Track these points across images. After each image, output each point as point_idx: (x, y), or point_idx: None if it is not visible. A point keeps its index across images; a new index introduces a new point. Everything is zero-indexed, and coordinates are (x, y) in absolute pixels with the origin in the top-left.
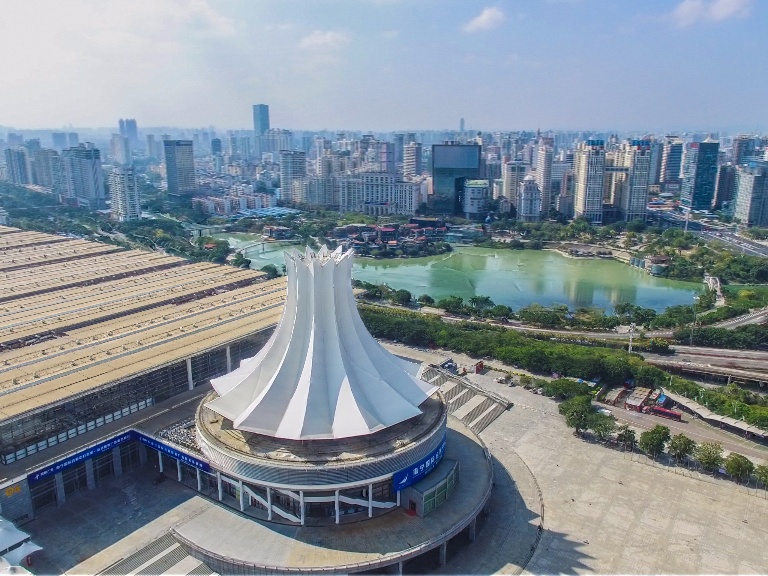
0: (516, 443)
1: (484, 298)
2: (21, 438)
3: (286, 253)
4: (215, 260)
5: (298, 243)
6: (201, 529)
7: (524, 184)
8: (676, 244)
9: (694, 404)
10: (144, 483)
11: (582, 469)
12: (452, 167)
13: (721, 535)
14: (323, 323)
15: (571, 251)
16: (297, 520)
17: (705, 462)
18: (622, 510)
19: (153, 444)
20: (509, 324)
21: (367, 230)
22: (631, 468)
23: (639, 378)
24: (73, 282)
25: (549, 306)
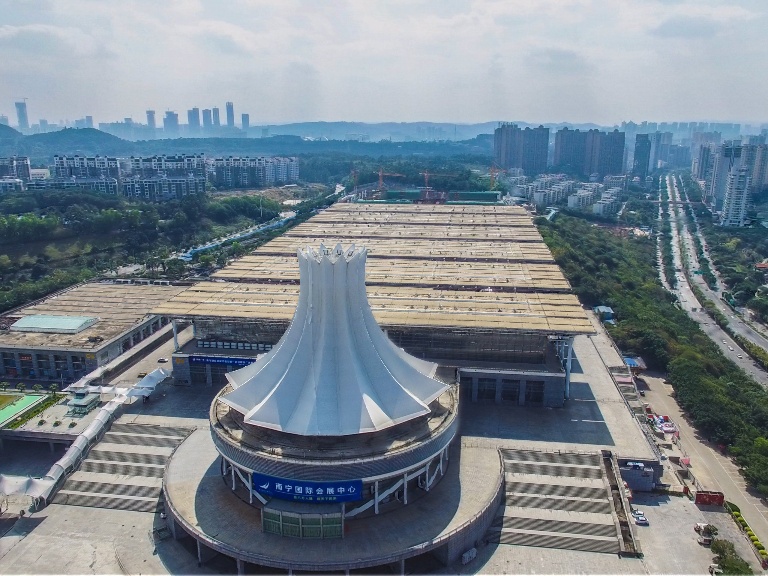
0: None
1: None
2: (208, 334)
3: (321, 245)
4: (726, 280)
5: None
6: (201, 438)
7: None
8: None
9: None
10: None
11: None
12: None
13: None
14: None
15: None
16: None
17: None
18: None
19: None
20: None
21: None
22: None
23: None
24: (431, 256)
25: None
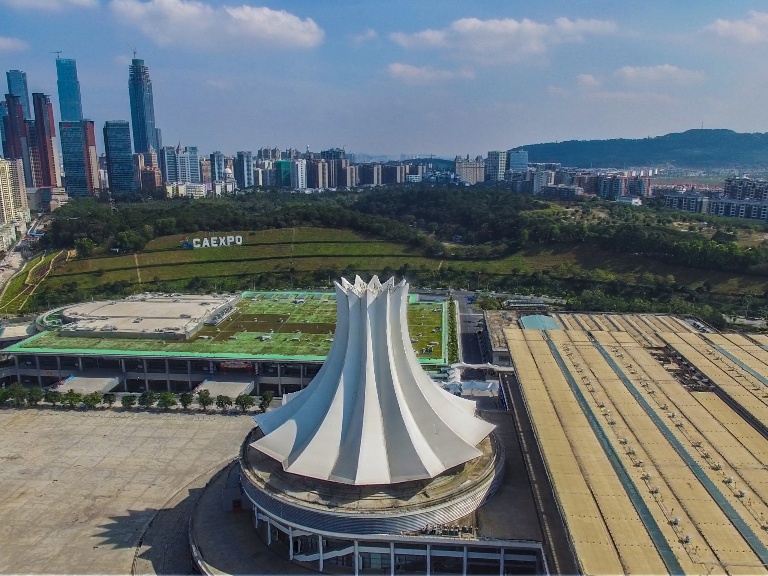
0: None
1: None
2: None
3: (403, 281)
4: None
5: None
6: None
7: None
8: None
9: None
10: None
11: None
12: None
13: None
14: None
15: None
16: None
17: None
18: None
19: None
20: None
21: None
22: None
23: None
24: None
25: None
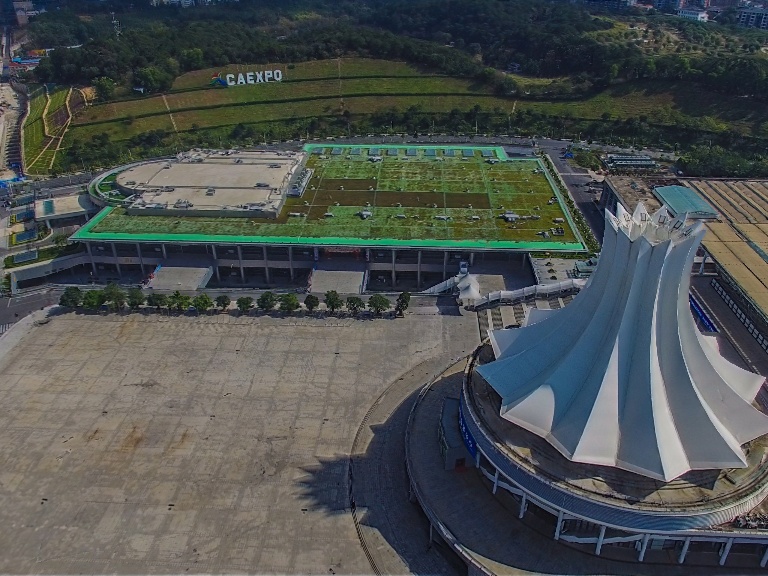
0: None
1: None
2: None
3: None
4: None
5: None
6: None
7: None
8: None
9: None
10: None
11: None
12: None
13: None
14: None
15: None
16: None
17: None
18: None
19: None
20: None
21: None
22: None
23: None
24: None
25: None
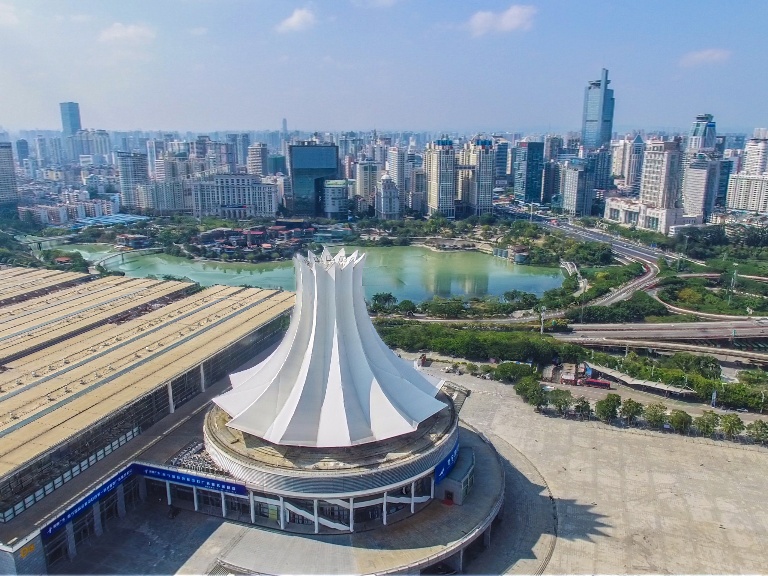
0: (491, 426)
1: (387, 295)
2: (19, 490)
3: None
4: None
5: (160, 251)
6: (250, 555)
7: (382, 183)
8: (528, 234)
9: (617, 373)
10: (157, 519)
11: (558, 441)
12: (311, 168)
13: (691, 479)
14: (343, 327)
15: (438, 245)
16: (345, 528)
17: (654, 420)
18: (608, 471)
19: (165, 475)
20: (416, 318)
21: (233, 234)
22: (596, 434)
23: (564, 355)
24: None
25: (445, 298)
